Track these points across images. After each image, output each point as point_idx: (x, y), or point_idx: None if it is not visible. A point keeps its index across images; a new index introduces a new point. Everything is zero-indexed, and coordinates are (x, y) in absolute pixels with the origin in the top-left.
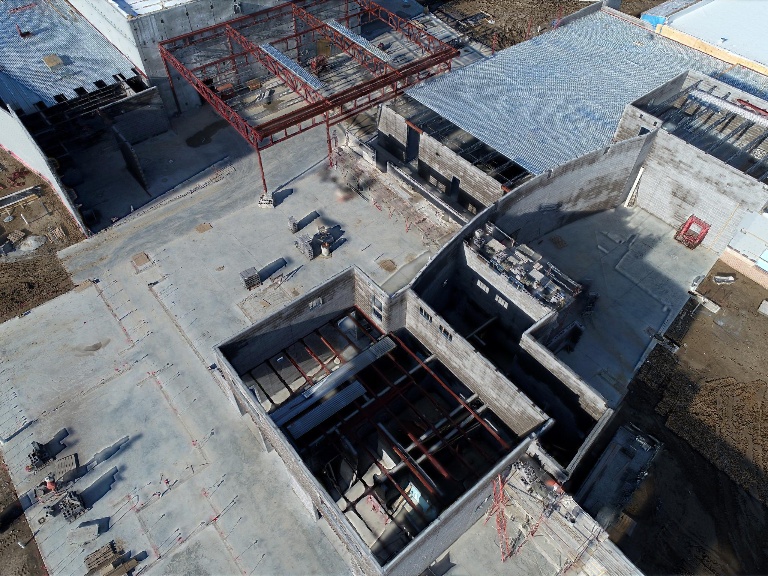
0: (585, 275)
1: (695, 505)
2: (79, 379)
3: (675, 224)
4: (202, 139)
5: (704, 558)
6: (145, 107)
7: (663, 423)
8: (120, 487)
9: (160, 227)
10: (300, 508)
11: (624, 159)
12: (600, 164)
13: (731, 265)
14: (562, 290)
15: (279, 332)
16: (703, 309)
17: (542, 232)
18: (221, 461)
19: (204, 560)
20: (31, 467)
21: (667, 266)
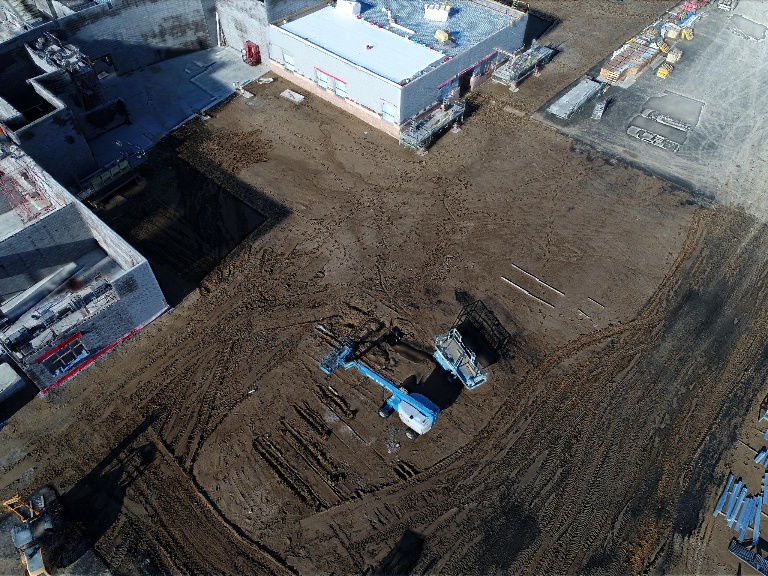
0: (165, 85)
1: (174, 190)
2: None
3: None
4: None
5: (164, 212)
6: None
7: (177, 155)
8: None
9: None
10: None
11: (188, 1)
12: (165, 4)
13: (277, 73)
14: (86, 66)
15: None
16: (242, 97)
17: (143, 63)
18: None
19: None
20: None
21: (229, 76)
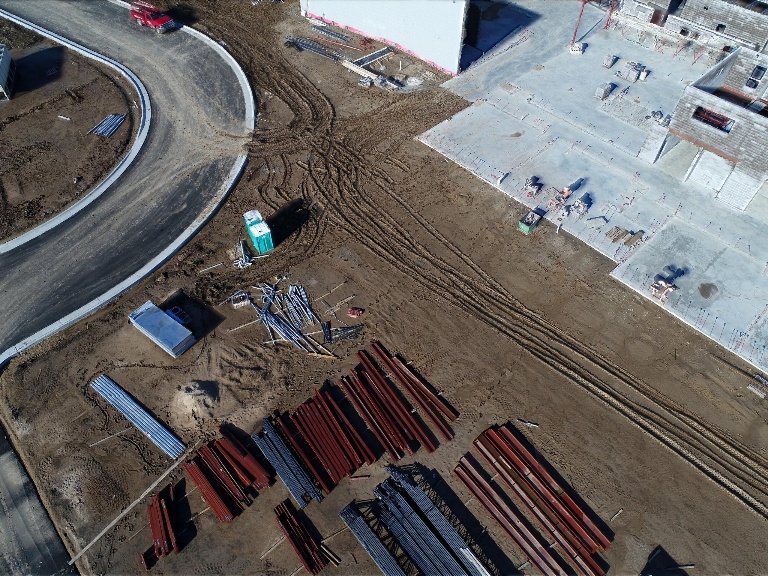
0: None
1: None
2: (521, 151)
3: None
4: (491, 15)
5: None
6: None
7: None
8: (598, 202)
9: (505, 68)
10: (727, 207)
11: None
12: None
13: None
14: None
15: None
16: None
17: None
18: (656, 187)
19: (683, 232)
20: (531, 193)
21: None
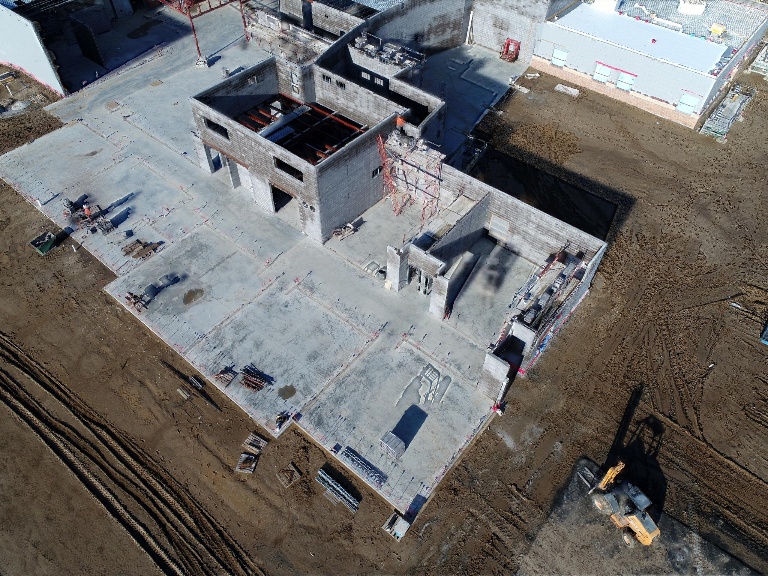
0: None
1: (513, 181)
2: (86, 170)
3: (500, 49)
4: (140, 33)
5: None
6: (90, 7)
7: (493, 148)
8: (135, 216)
9: (122, 86)
10: (262, 210)
11: (456, 1)
12: (439, 3)
13: (538, 69)
14: None
15: (230, 99)
16: (519, 92)
17: None
18: (202, 196)
19: (203, 239)
20: (67, 213)
21: (495, 73)
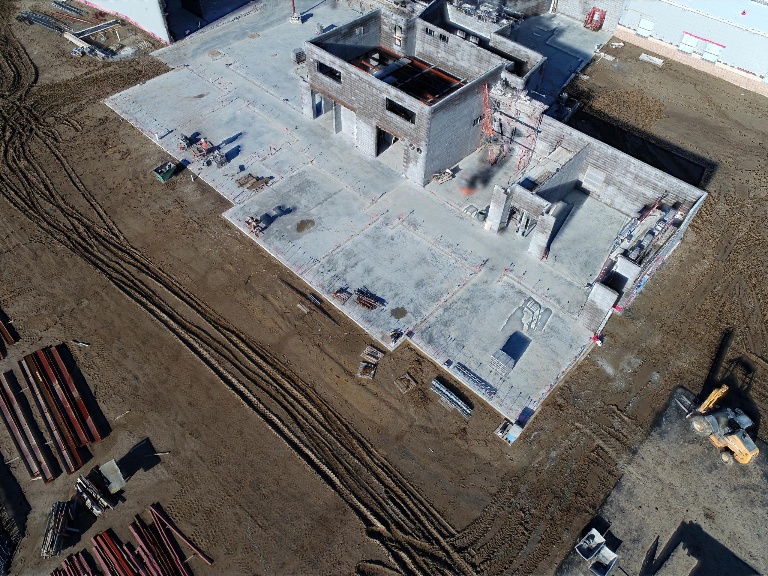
0: None
1: (602, 141)
2: (196, 110)
3: (584, 19)
4: None
5: None
6: None
7: (581, 110)
8: (245, 153)
9: (222, 37)
10: (363, 154)
11: None
12: None
13: (622, 38)
14: None
15: (339, 47)
16: (604, 60)
17: None
18: (306, 139)
19: (310, 177)
20: (183, 147)
21: (580, 40)
